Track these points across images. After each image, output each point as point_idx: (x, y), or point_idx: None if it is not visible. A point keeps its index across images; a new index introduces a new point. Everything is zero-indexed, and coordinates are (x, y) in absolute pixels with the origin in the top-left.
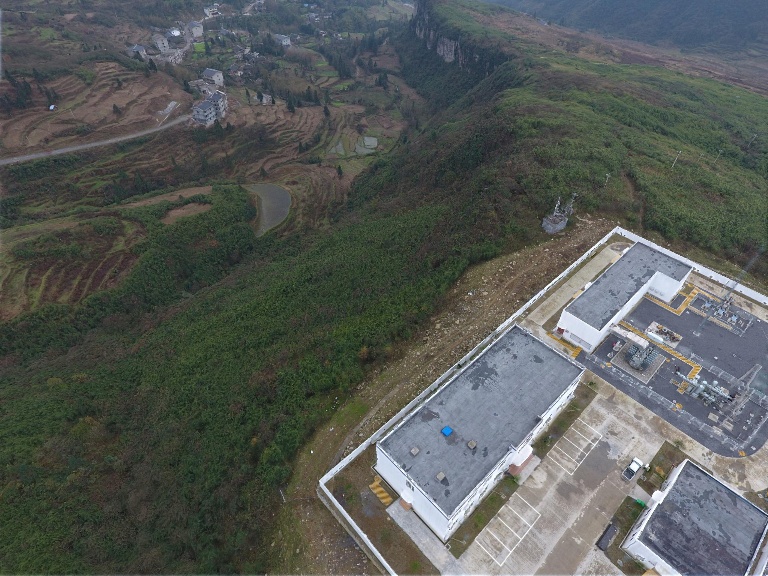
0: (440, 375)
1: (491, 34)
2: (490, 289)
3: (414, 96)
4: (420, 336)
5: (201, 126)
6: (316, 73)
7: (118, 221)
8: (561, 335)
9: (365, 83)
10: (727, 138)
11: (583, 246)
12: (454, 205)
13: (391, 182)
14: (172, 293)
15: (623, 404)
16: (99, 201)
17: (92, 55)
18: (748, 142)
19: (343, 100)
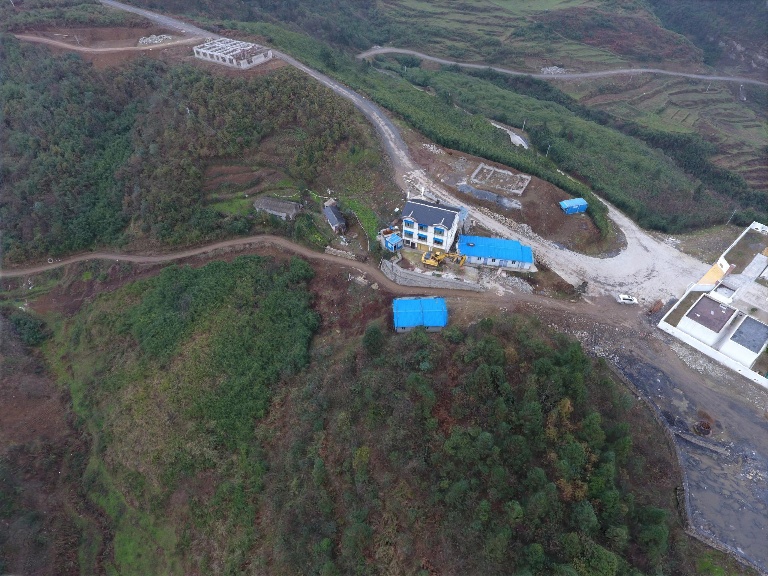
0: None
1: None
2: None
3: None
4: None
5: None
6: None
7: None
8: None
9: None
10: None
11: None
12: None
13: None
14: None
15: None
16: None
17: None
18: None
19: None
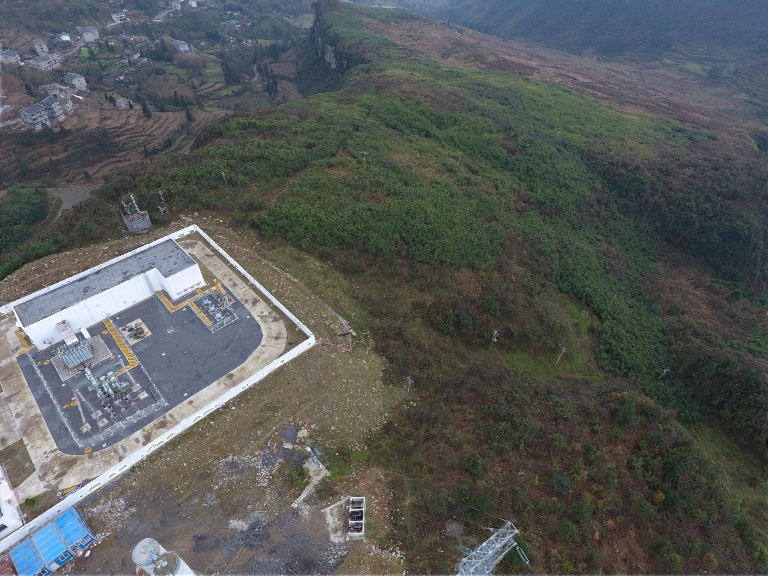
0: None
1: (368, 41)
2: (4, 287)
3: None
4: None
5: (29, 130)
6: (202, 78)
7: None
8: None
9: (254, 89)
10: (495, 141)
11: None
12: None
13: None
14: None
15: (17, 402)
16: None
17: None
18: None
19: (218, 105)
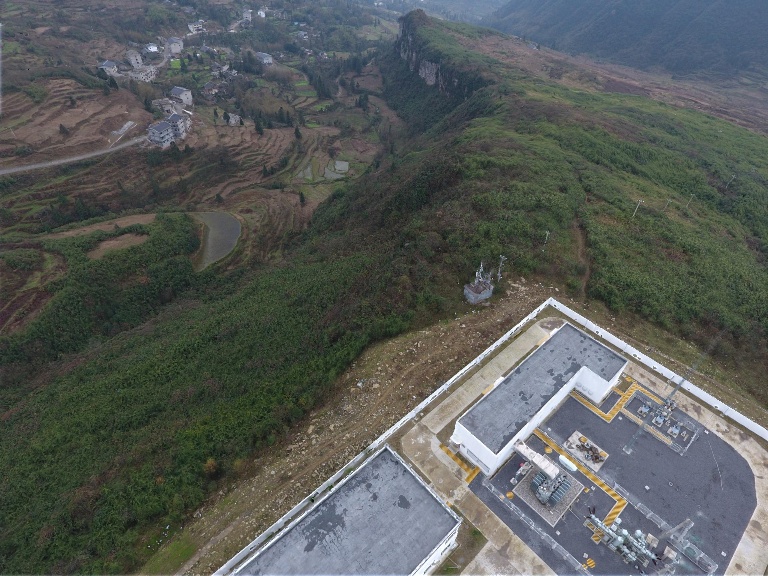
0: (291, 507)
1: (473, 58)
2: (383, 380)
3: (394, 118)
4: (287, 442)
5: (157, 148)
6: (294, 93)
7: (38, 254)
8: (457, 449)
9: (345, 104)
10: (703, 178)
11: (508, 321)
12: (381, 257)
13: (343, 216)
14: (87, 337)
15: (518, 559)
16: (34, 227)
17: (46, 71)
18: (726, 183)
19: (318, 121)
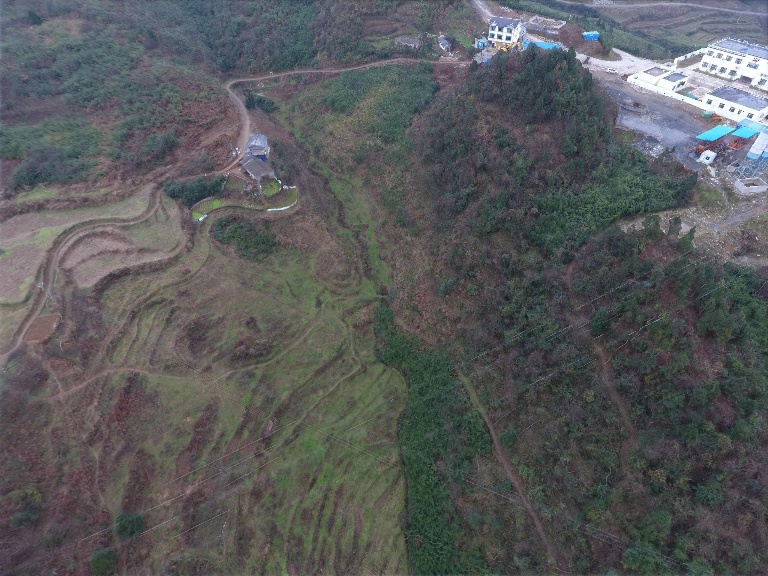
0: None
1: None
2: None
3: None
4: None
5: None
6: None
7: None
8: None
9: None
10: None
11: None
12: None
13: None
14: None
15: None
16: None
17: None
18: None
19: None
